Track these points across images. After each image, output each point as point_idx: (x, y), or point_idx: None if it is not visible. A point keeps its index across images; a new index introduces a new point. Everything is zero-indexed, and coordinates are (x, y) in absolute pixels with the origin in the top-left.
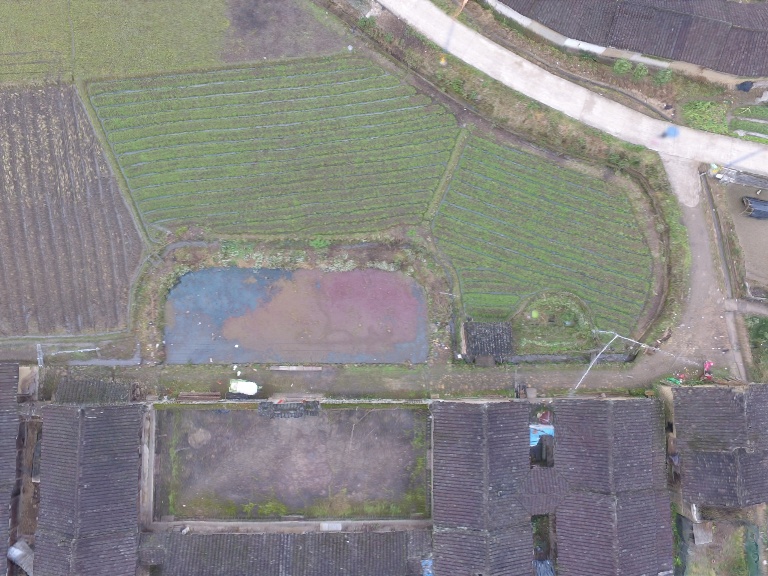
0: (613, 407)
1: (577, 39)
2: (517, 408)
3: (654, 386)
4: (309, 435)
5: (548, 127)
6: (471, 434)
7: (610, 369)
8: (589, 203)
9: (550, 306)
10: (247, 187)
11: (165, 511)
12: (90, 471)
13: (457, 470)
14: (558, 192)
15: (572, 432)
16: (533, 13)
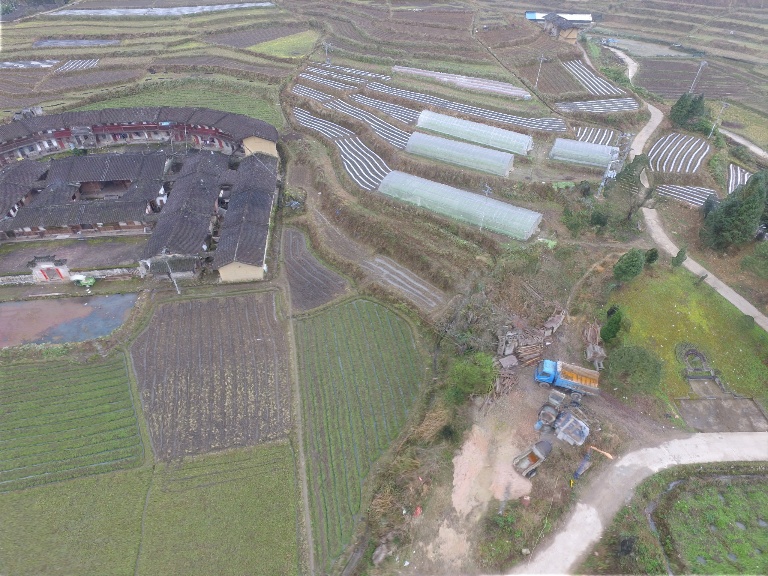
0: None
1: None
2: None
3: None
4: None
5: None
6: None
7: None
8: None
9: None
10: None
11: None
12: None
13: None
14: None
15: None
16: None
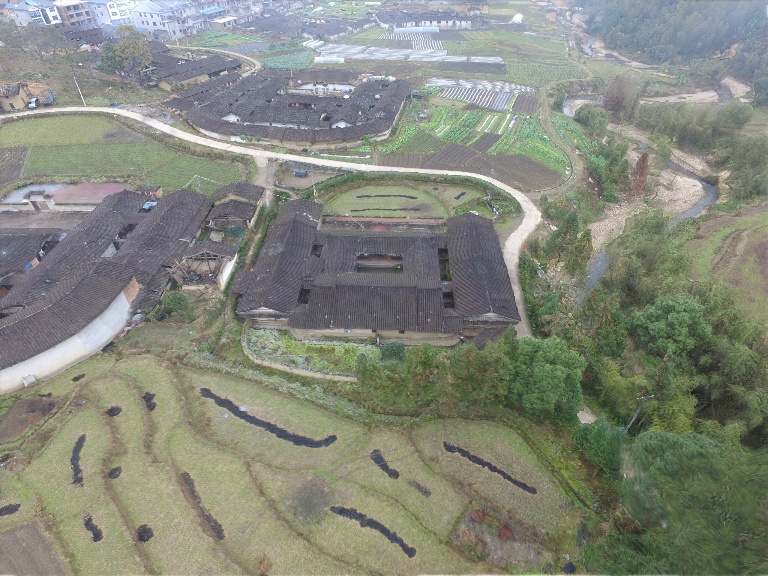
0: (182, 190)
1: (230, 135)
2: None
3: None
4: (45, 219)
5: (209, 151)
6: None
7: None
8: None
9: (186, 188)
10: None
11: None
12: None
13: None
14: None
15: None
16: (216, 130)
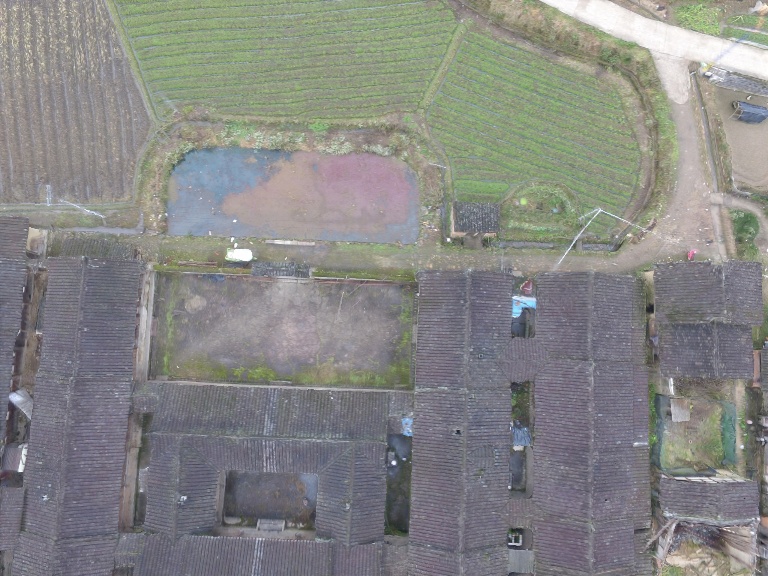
0: (594, 277)
1: None
2: (501, 278)
3: (638, 274)
4: (300, 306)
5: (542, 22)
6: (455, 299)
7: (595, 256)
8: (580, 98)
9: (538, 193)
10: (251, 72)
11: (160, 371)
12: (90, 316)
13: (440, 334)
14: (550, 87)
15: (554, 303)
16: None
